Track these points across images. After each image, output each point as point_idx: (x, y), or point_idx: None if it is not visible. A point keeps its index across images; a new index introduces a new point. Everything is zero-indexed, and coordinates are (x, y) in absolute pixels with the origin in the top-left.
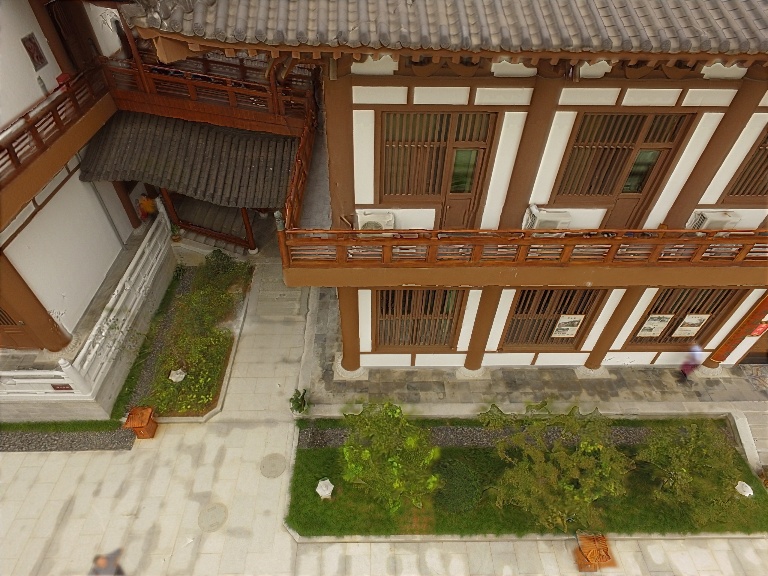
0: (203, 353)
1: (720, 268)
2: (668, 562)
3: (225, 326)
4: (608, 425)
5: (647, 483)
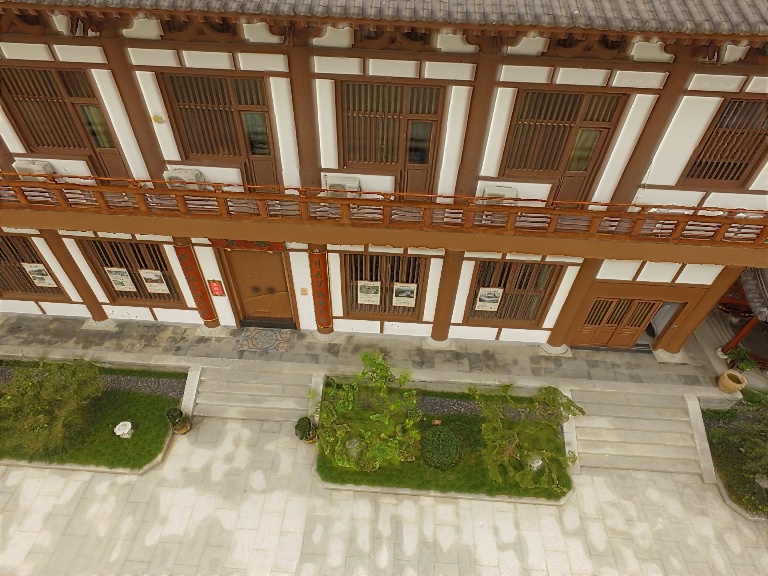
0: None
1: (15, 210)
2: (17, 486)
3: None
4: None
5: None
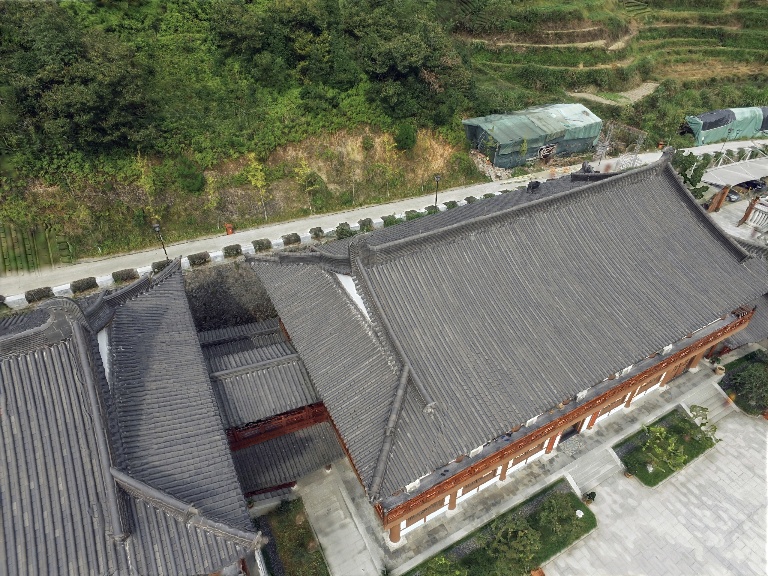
0: (315, 574)
1: None
2: (567, 564)
3: (311, 549)
4: (524, 518)
5: (546, 531)
